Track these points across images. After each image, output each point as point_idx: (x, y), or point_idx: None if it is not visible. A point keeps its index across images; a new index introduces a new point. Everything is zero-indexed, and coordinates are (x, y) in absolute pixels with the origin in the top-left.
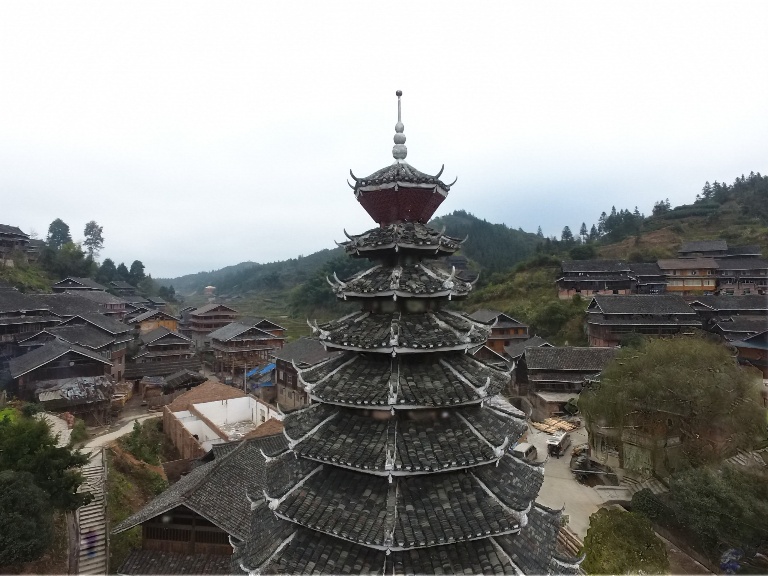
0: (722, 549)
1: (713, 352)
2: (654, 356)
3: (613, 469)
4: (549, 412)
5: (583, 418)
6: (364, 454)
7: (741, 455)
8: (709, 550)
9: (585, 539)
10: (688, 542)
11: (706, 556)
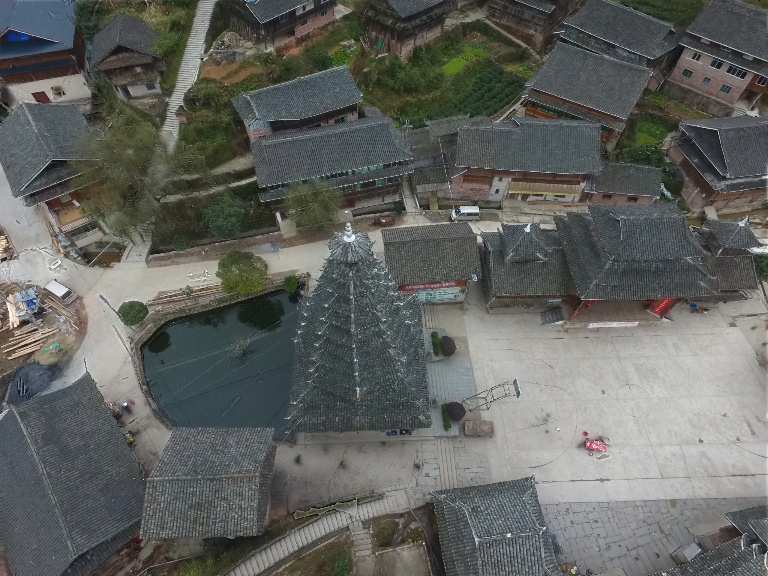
0: (209, 229)
1: (148, 135)
2: (131, 162)
3: (105, 240)
4: (44, 248)
5: (118, 233)
6: (395, 311)
7: (214, 187)
8: (228, 236)
9: (232, 283)
10: (195, 239)
11: (208, 238)
